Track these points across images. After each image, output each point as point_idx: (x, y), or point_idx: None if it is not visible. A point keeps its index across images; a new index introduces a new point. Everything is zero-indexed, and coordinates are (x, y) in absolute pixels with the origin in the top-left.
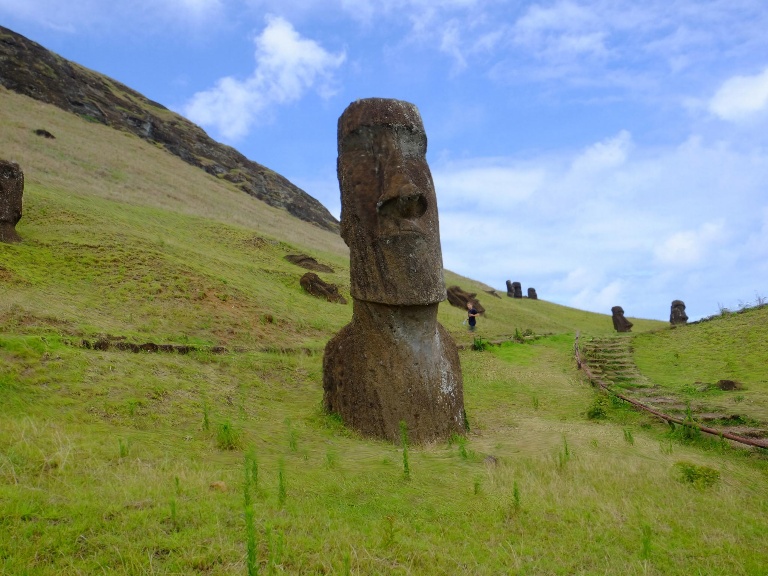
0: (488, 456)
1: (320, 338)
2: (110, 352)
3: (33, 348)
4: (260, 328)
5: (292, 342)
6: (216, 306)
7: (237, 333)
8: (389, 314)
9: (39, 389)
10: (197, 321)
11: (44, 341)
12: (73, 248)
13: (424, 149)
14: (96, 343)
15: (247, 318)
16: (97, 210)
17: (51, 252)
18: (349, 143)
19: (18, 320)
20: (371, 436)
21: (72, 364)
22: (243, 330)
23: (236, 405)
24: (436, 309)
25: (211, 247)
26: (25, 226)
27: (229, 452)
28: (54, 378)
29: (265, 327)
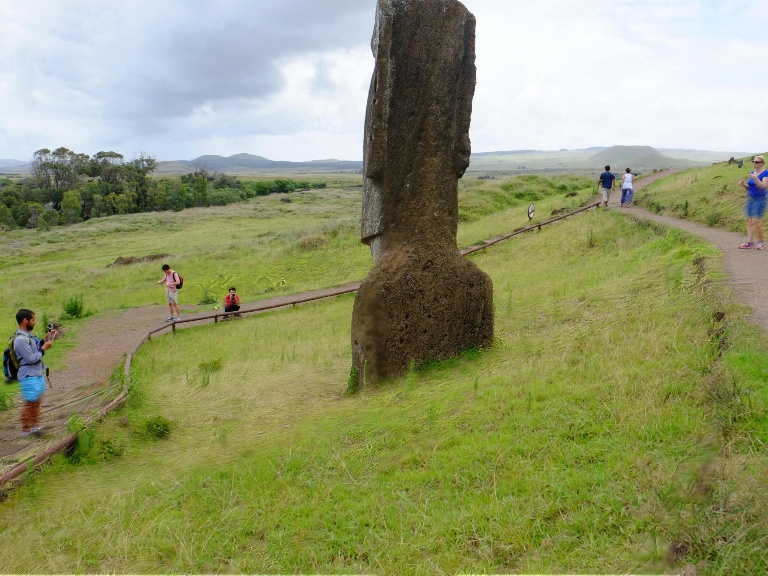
0: (341, 353)
1: None
2: None
3: None
4: None
5: None
6: None
7: None
8: None
9: None
10: None
11: None
12: None
13: None
14: None
15: None
16: None
17: None
18: None
19: None
20: None
21: None
22: None
23: None
24: None
25: None
26: None
27: None
28: None
29: None
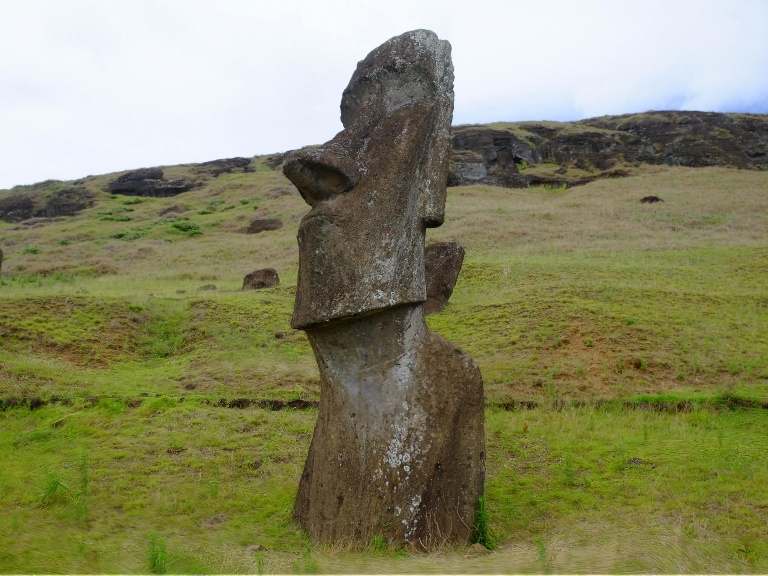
0: (191, 574)
1: (716, 386)
2: (245, 410)
3: (150, 407)
4: (602, 377)
5: (634, 394)
6: (569, 354)
7: (548, 385)
8: (314, 342)
9: (84, 441)
10: (507, 374)
11: (181, 401)
12: (477, 310)
13: (431, 84)
14: (236, 401)
15: (596, 365)
16: (588, 266)
17: (450, 318)
18: (348, 123)
19: (278, 384)
20: (297, 523)
21: (158, 421)
22: (566, 381)
23: (261, 468)
24: (382, 325)
25: (738, 280)
26: (485, 296)
27: (28, 511)
28: (119, 433)
29: (613, 375)
